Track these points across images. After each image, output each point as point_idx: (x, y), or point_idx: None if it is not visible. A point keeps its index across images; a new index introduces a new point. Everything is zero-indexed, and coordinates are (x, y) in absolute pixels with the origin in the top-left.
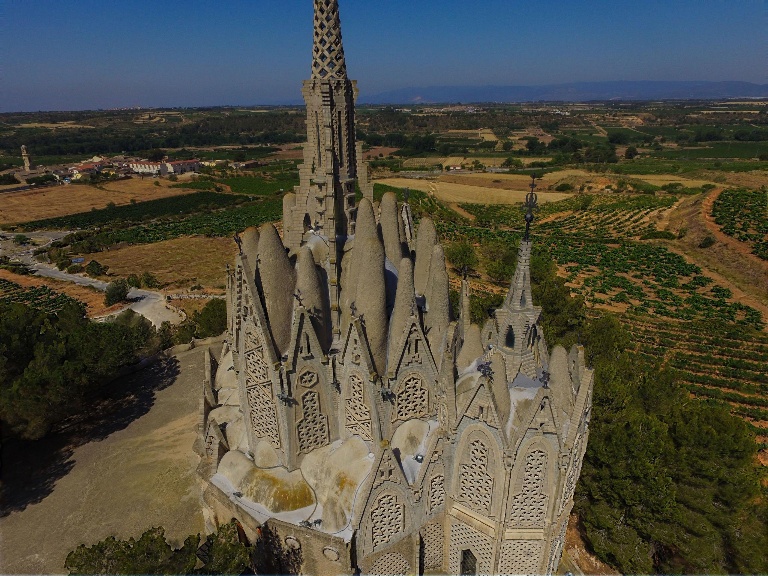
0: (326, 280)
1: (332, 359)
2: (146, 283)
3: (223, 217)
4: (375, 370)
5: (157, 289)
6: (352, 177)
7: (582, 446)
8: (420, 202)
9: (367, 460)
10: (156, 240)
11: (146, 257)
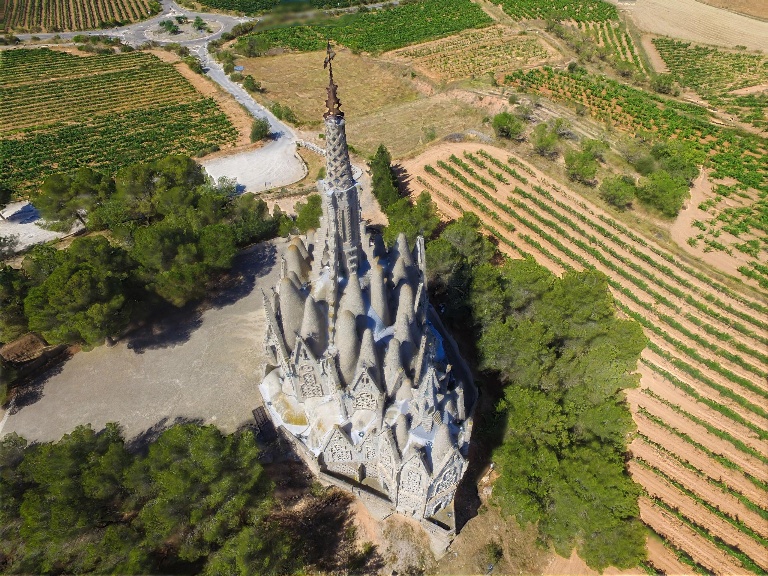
0: (328, 310)
1: (322, 362)
2: (286, 117)
3: (377, 20)
4: (343, 381)
5: (294, 126)
6: (355, 245)
7: (463, 467)
8: (600, 34)
9: (338, 418)
10: (308, 46)
11: (295, 72)
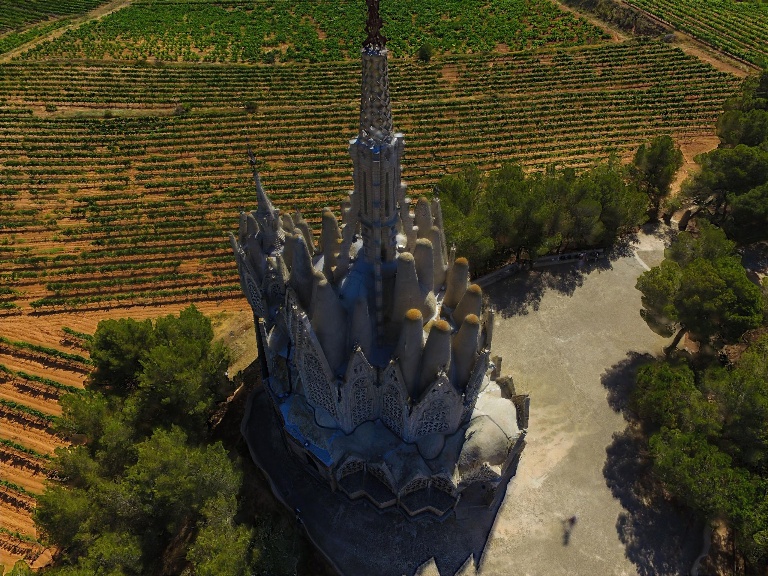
0: None
1: None
2: None
3: None
4: None
5: None
6: None
7: None
8: None
9: None
10: None
11: None
